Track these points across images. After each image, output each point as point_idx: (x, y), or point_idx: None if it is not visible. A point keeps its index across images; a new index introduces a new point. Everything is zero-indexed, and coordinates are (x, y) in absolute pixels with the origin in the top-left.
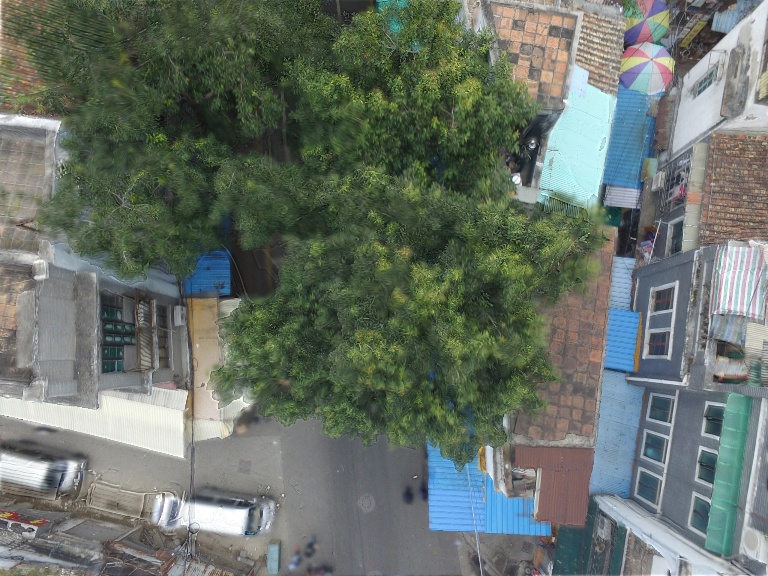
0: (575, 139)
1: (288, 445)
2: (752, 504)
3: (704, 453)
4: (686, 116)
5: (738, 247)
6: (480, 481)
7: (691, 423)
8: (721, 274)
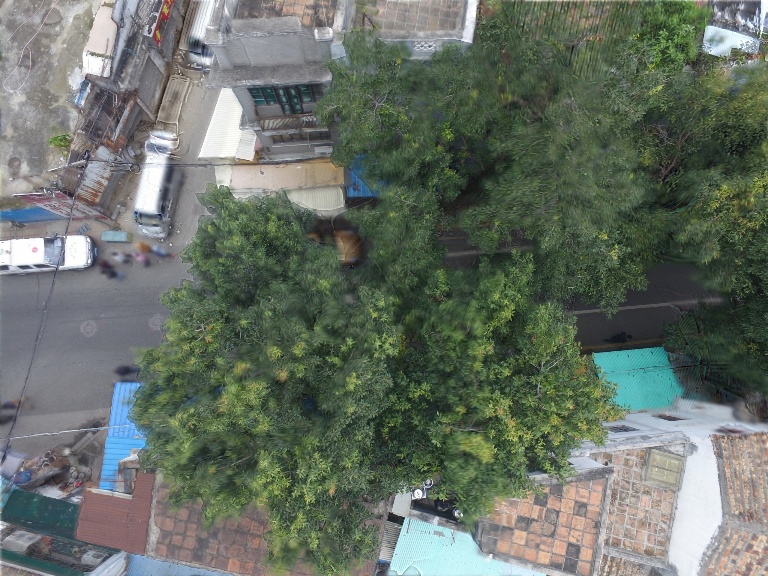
0: (483, 562)
1: None
2: None
3: None
4: None
5: None
6: None
7: None
8: None
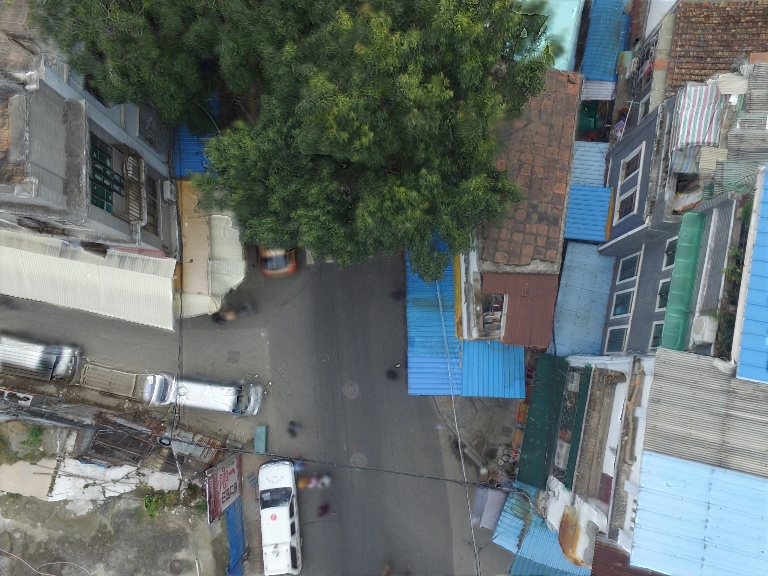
0: (547, 9)
1: (275, 337)
2: (702, 303)
3: (664, 284)
4: (658, 1)
5: (696, 86)
6: (457, 348)
7: (654, 266)
8: (680, 113)
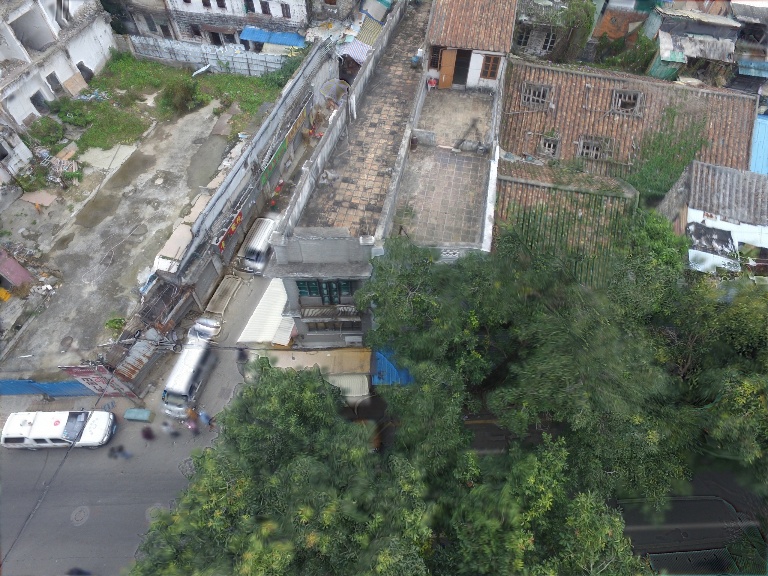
0: None
1: None
2: None
3: None
4: None
5: None
6: None
7: None
8: None
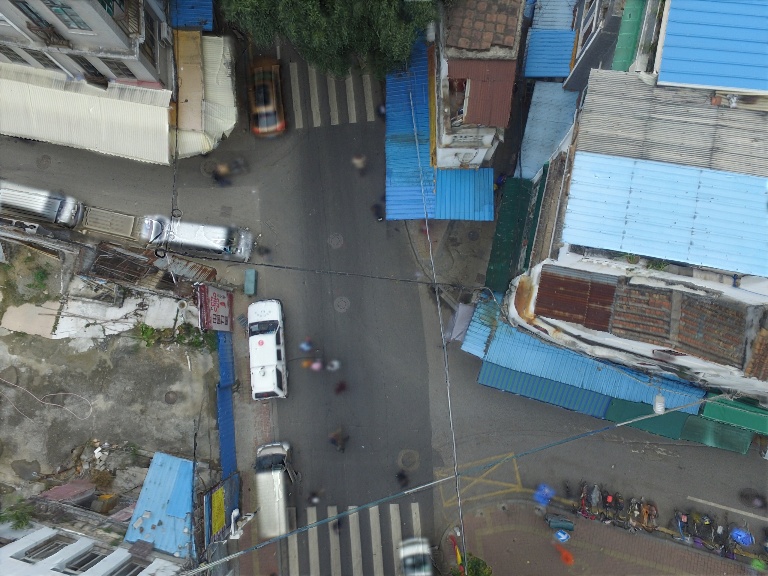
0: None
1: (266, 194)
2: None
3: None
4: None
5: None
6: (431, 176)
7: None
8: None
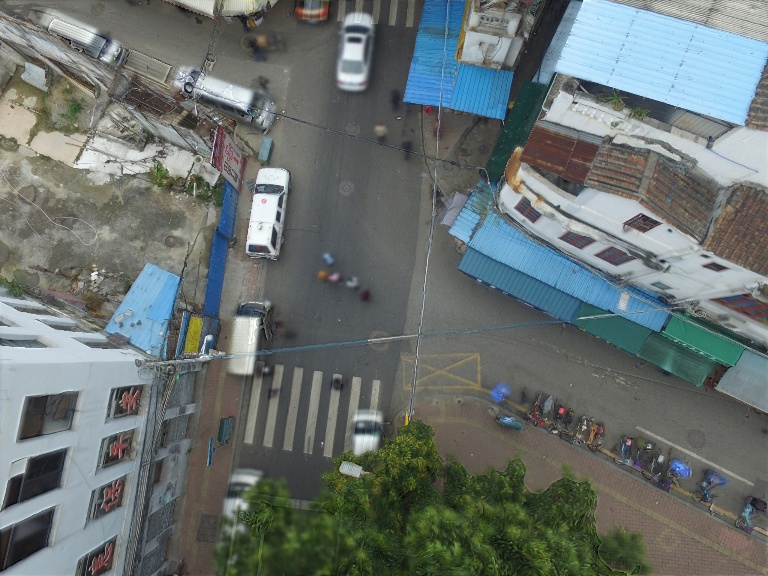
0: None
1: (296, 75)
2: None
3: None
4: None
5: None
6: (454, 68)
7: None
8: None
